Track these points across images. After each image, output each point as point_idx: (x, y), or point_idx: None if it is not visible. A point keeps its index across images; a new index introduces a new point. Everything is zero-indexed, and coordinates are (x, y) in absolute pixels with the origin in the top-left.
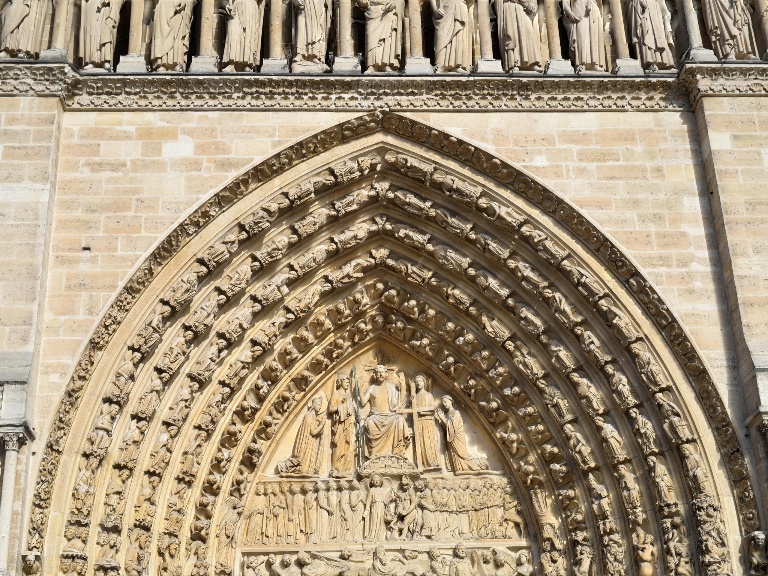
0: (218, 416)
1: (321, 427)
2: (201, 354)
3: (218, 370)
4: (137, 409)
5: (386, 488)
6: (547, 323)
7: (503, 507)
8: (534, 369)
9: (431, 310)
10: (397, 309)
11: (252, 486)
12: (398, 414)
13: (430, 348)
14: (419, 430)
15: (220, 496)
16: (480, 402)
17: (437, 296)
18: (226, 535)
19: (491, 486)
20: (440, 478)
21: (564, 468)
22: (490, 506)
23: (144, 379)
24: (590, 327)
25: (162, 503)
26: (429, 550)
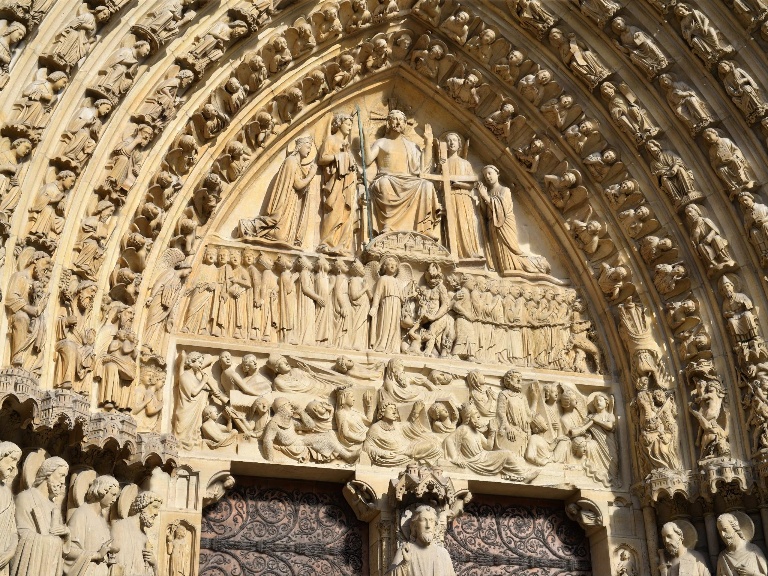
0: (171, 110)
1: (309, 180)
2: (155, 5)
3: (176, 41)
4: (50, 51)
5: (402, 280)
6: (671, 58)
7: (569, 329)
8: (645, 123)
9: (490, 29)
10: (434, 28)
11: (198, 248)
12: (423, 178)
13: (477, 91)
14: (451, 207)
15: (155, 245)
16: (546, 175)
17: (500, 11)
18: (162, 305)
19: (553, 297)
20: (483, 276)
21: (682, 268)
22: (553, 324)
23: (66, 7)
24: (740, 64)
25: (71, 222)
26: (468, 374)
